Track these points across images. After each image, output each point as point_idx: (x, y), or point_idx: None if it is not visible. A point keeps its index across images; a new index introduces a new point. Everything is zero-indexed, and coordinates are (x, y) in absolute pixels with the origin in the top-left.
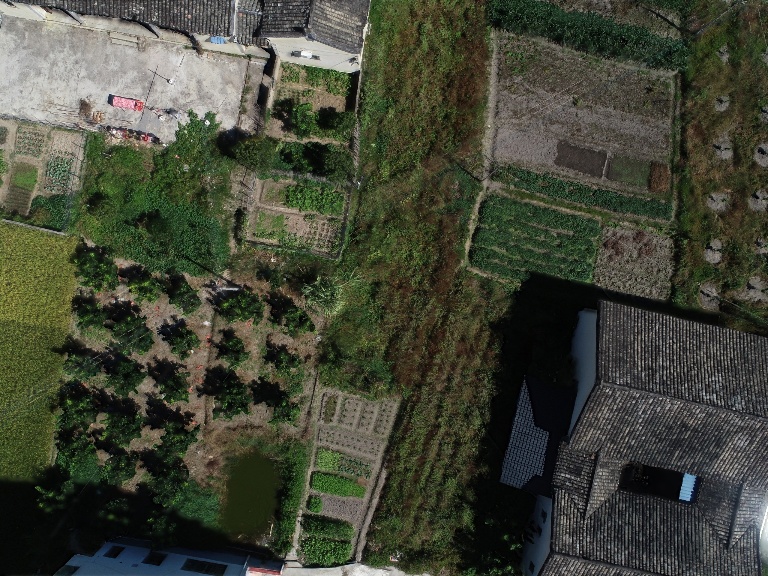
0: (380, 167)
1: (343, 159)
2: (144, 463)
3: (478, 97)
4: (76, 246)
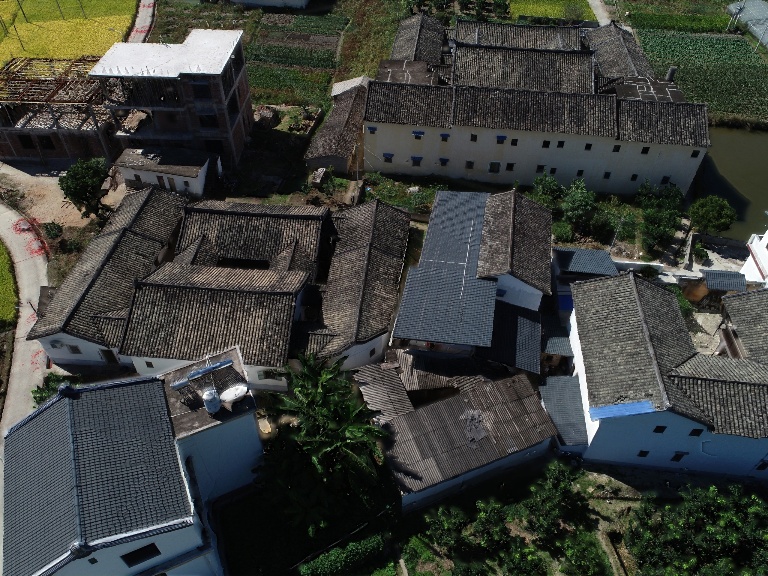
0: None
1: None
2: None
3: None
4: None
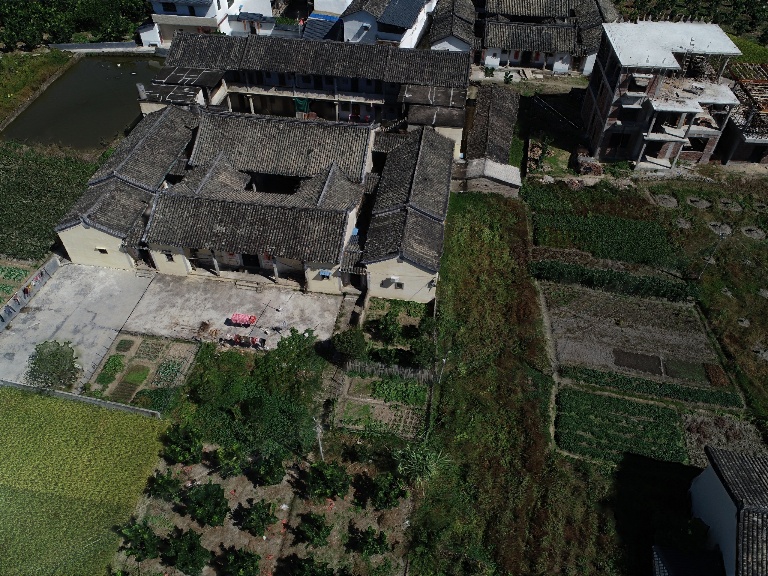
0: (458, 367)
1: (428, 345)
2: None
3: (535, 318)
4: (168, 427)
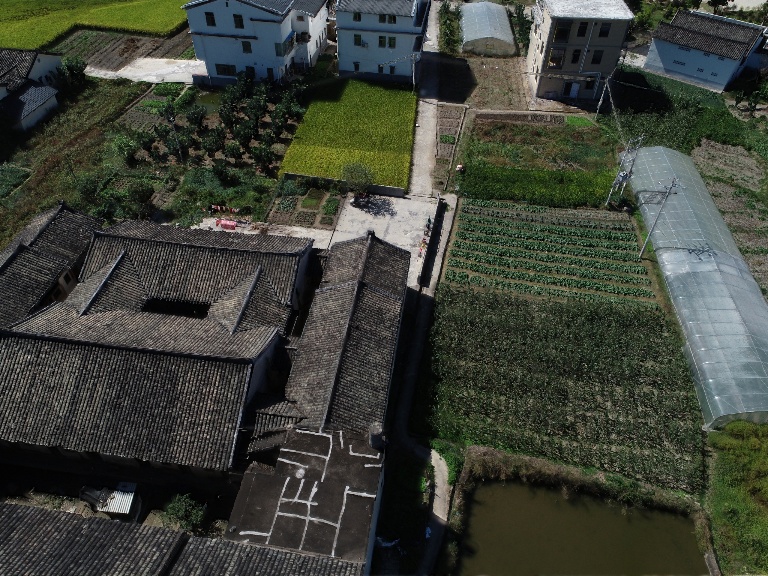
0: None
1: None
2: None
3: None
4: None
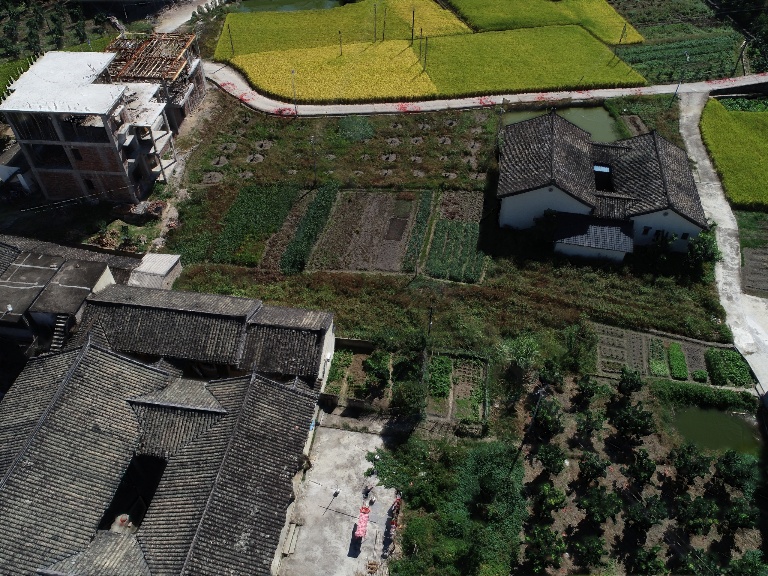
0: None
1: None
2: (726, 520)
3: None
4: None
